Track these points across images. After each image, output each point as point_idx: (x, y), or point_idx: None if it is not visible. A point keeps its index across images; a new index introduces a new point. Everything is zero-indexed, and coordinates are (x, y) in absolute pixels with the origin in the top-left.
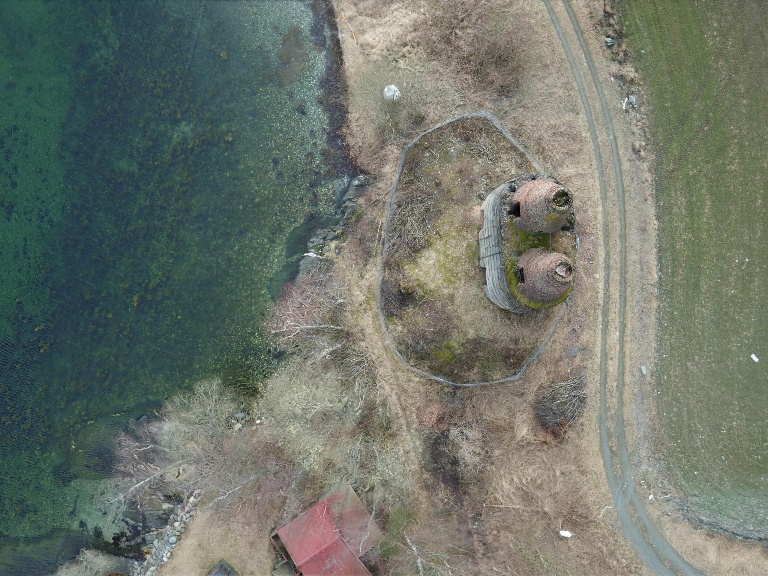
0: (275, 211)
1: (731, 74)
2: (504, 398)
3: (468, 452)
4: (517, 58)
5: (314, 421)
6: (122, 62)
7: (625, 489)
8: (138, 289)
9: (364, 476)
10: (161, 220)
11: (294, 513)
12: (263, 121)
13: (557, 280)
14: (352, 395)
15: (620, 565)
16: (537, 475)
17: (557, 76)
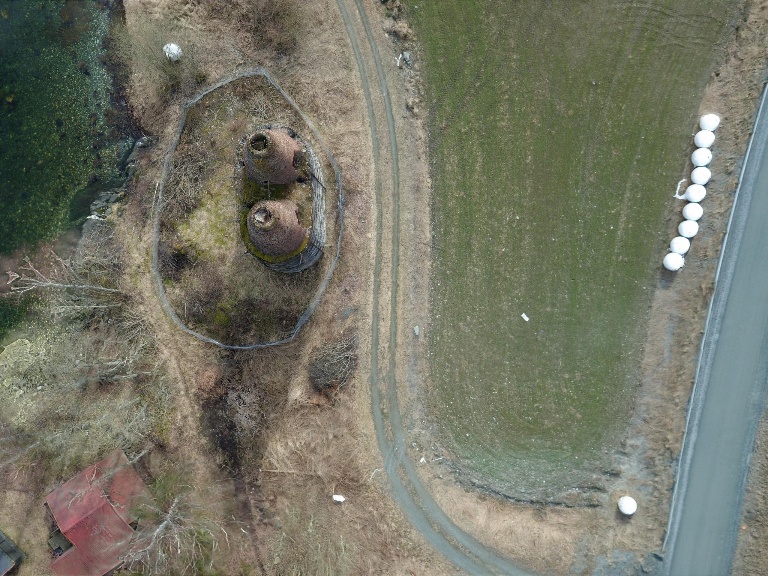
0: (59, 173)
1: (502, 29)
2: (281, 361)
3: (245, 416)
4: (293, 15)
5: (92, 386)
6: None
7: (396, 452)
8: None
9: (140, 442)
10: None
11: None
12: (46, 82)
13: (256, 226)
14: None
15: (390, 529)
16: (311, 439)
17: (331, 32)
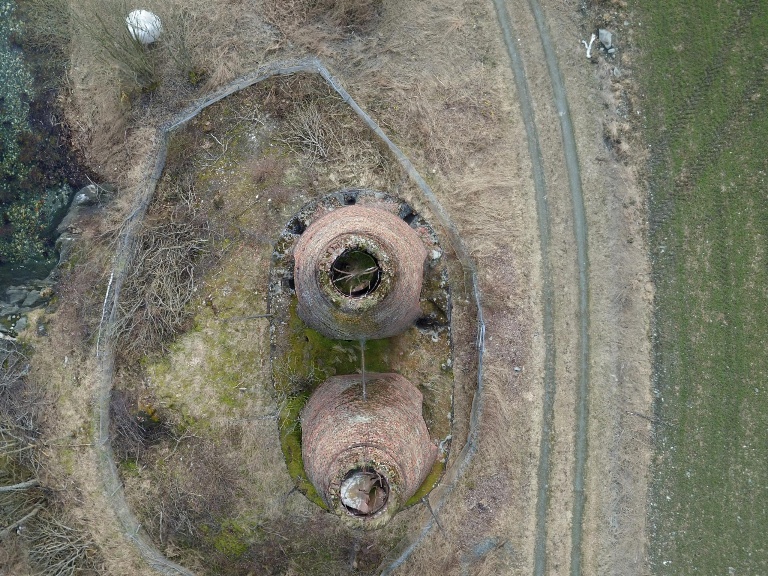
0: None
1: None
2: None
3: None
4: None
5: None
6: None
7: None
8: None
9: None
10: None
11: None
12: None
13: None
14: None
15: None
16: None
17: None
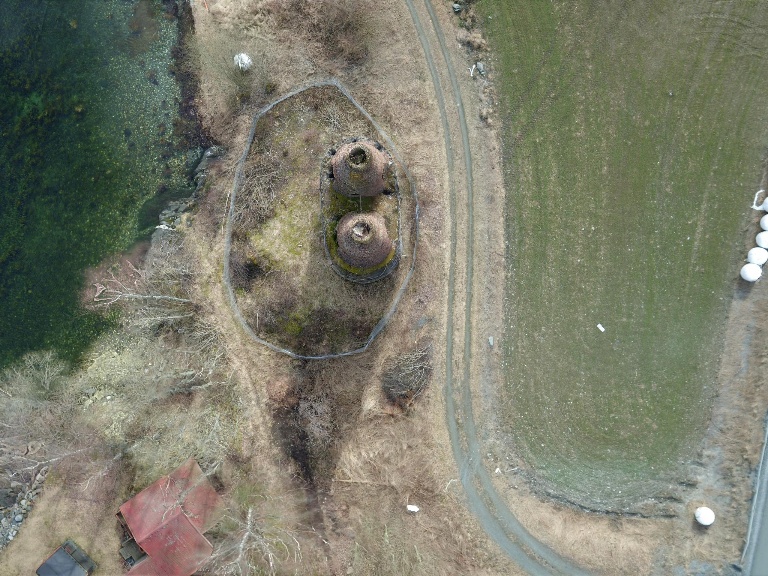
0: (127, 183)
1: (577, 39)
2: (353, 371)
3: (317, 426)
4: (365, 25)
5: (163, 396)
6: None
7: (471, 462)
8: None
9: (212, 451)
10: (12, 193)
11: None
12: (115, 91)
13: (354, 240)
14: None
15: (465, 539)
16: (385, 449)
17: (404, 43)
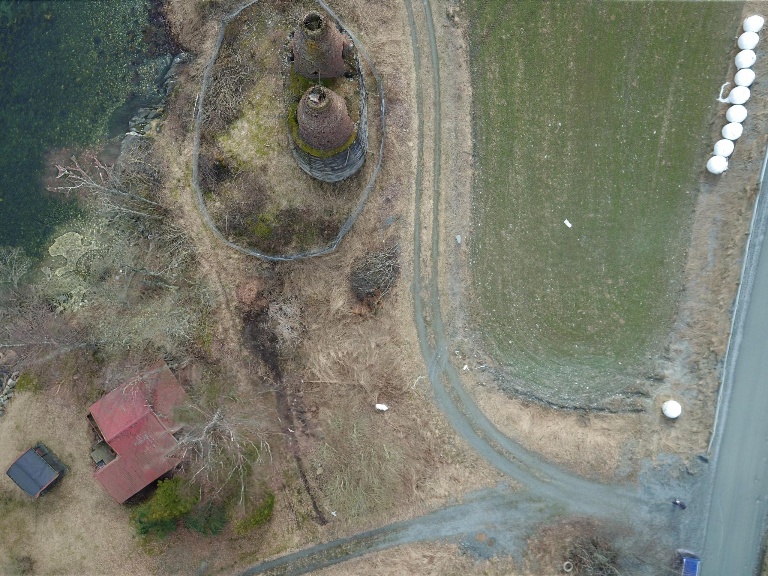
0: (97, 90)
1: None
2: (322, 272)
3: (286, 328)
4: None
5: (133, 300)
6: None
7: (439, 359)
8: None
9: (182, 354)
10: None
11: None
12: None
13: (310, 106)
14: None
15: (434, 436)
16: (353, 348)
17: None
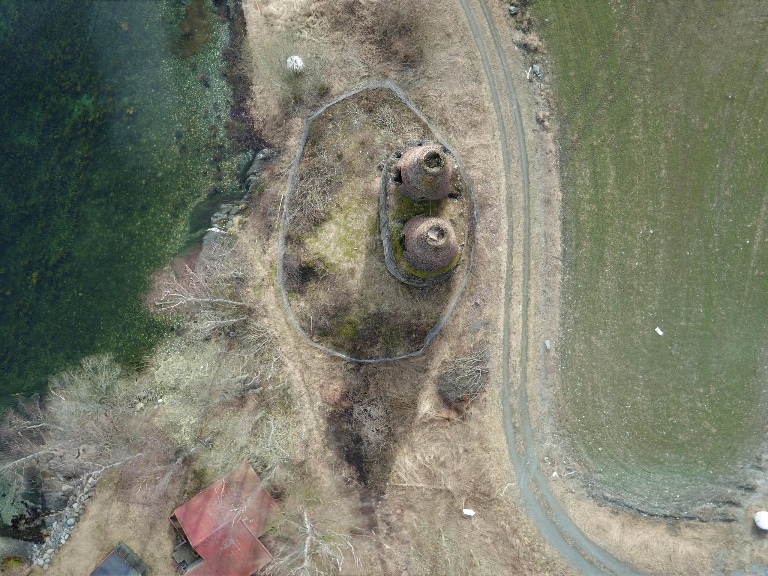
0: (178, 186)
1: (635, 42)
2: (408, 374)
3: (371, 430)
4: (420, 27)
5: (216, 399)
6: (21, 34)
7: (528, 466)
8: (38, 266)
9: (266, 455)
10: (62, 195)
11: (195, 493)
12: (166, 94)
13: (429, 244)
14: (253, 372)
15: (523, 543)
16: (440, 452)
17: (460, 45)
